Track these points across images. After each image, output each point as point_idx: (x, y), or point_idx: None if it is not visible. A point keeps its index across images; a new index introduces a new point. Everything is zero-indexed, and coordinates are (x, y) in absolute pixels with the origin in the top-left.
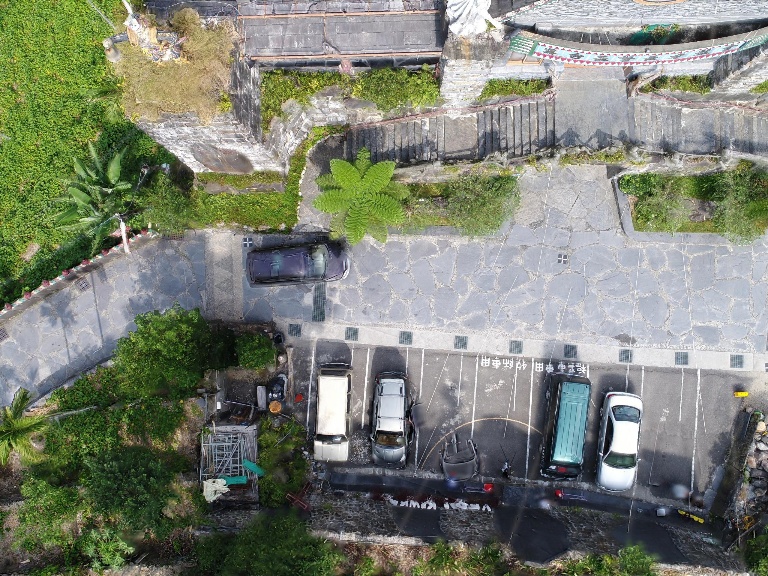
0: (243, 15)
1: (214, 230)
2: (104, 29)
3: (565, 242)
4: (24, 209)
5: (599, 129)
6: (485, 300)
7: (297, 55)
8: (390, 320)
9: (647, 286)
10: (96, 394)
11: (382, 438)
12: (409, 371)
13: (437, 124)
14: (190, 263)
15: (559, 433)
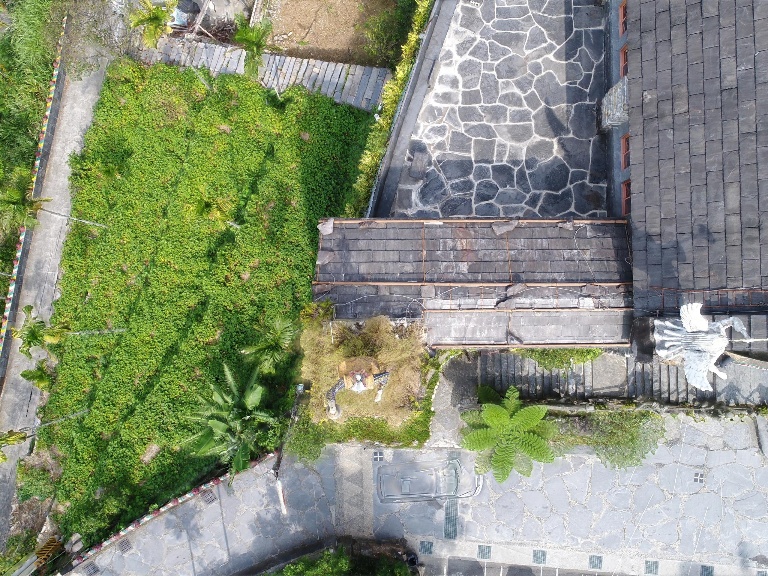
0: (427, 309)
1: (344, 444)
2: None
3: (701, 461)
4: (144, 410)
5: (761, 383)
6: (620, 519)
7: (479, 344)
8: (523, 538)
9: None
10: None
11: None
12: None
13: None
14: (319, 477)
15: None
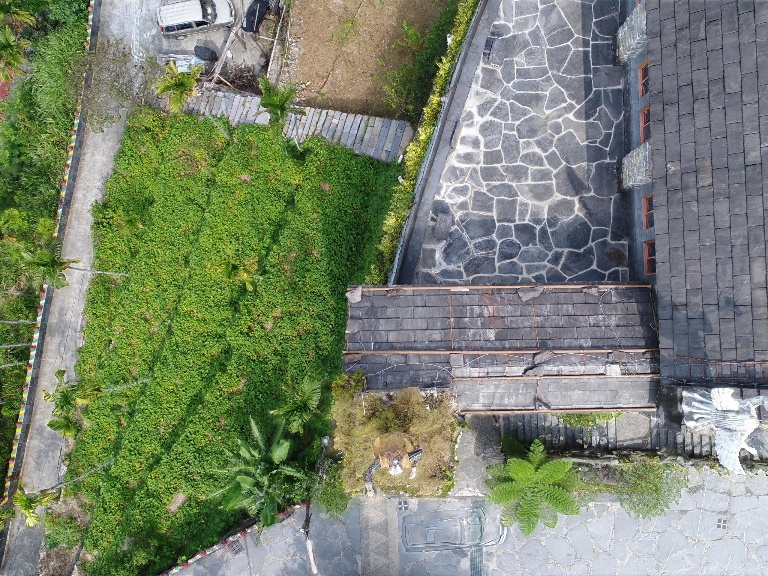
0: (456, 377)
1: None
2: None
3: (724, 507)
4: (170, 460)
5: None
6: (644, 566)
7: (507, 410)
8: None
9: None
10: None
11: None
12: None
13: None
14: (345, 527)
15: None
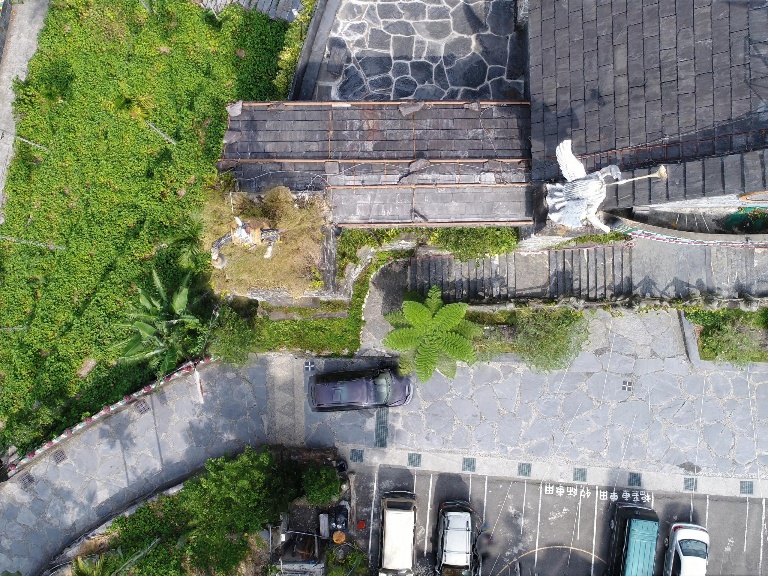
0: (332, 185)
1: (276, 353)
2: (159, 138)
3: (630, 369)
4: (80, 325)
5: (676, 277)
6: (549, 427)
7: (384, 222)
8: (453, 446)
9: (712, 414)
10: (158, 523)
11: (447, 570)
12: (472, 498)
13: (507, 260)
14: (251, 387)
15: (628, 570)
